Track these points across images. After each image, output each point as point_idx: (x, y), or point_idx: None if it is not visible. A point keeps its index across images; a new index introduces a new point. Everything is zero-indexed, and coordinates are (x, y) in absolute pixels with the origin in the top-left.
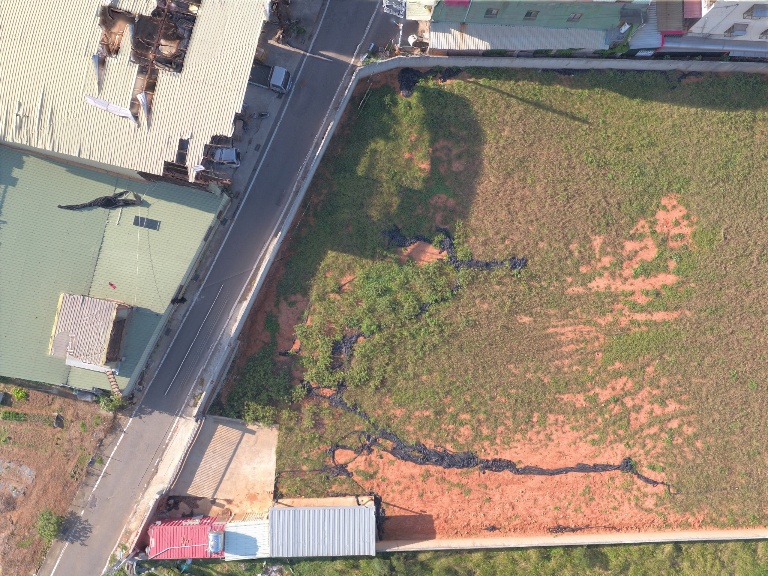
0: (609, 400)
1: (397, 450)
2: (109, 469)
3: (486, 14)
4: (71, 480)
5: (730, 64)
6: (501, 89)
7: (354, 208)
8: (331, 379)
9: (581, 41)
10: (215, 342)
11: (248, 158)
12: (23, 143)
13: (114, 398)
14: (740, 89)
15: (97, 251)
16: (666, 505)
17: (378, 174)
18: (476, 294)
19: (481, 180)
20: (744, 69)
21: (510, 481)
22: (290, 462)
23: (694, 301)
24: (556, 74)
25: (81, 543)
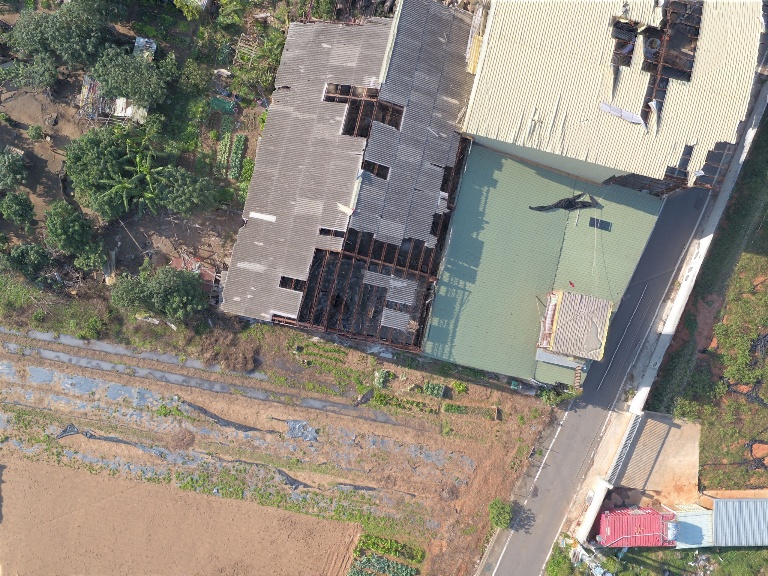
0: None
1: None
2: (548, 460)
3: None
4: (510, 471)
5: None
6: None
7: (765, 212)
8: (751, 376)
9: None
10: (643, 339)
11: None
12: (533, 147)
13: (573, 392)
14: None
15: (559, 251)
16: None
17: None
18: None
19: None
20: None
21: None
22: (712, 455)
23: None
24: None
25: (526, 531)
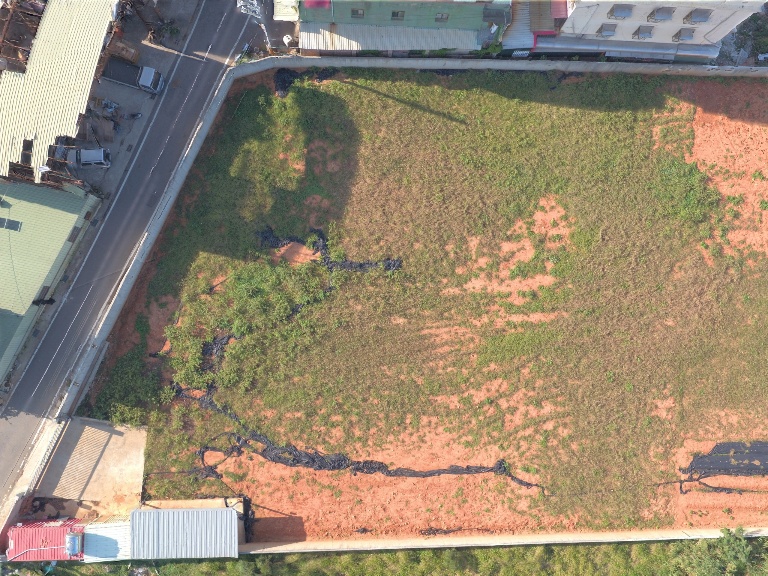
0: (483, 402)
1: (267, 452)
2: None
3: (353, 14)
4: None
5: (608, 64)
6: (377, 89)
7: (226, 209)
8: (200, 380)
9: (453, 41)
10: (83, 343)
11: (120, 159)
12: None
13: None
14: (620, 89)
15: None
16: (540, 507)
17: (251, 175)
18: (349, 295)
19: (356, 181)
20: (624, 69)
21: (382, 483)
22: (158, 464)
23: (571, 302)
24: (434, 74)
25: None
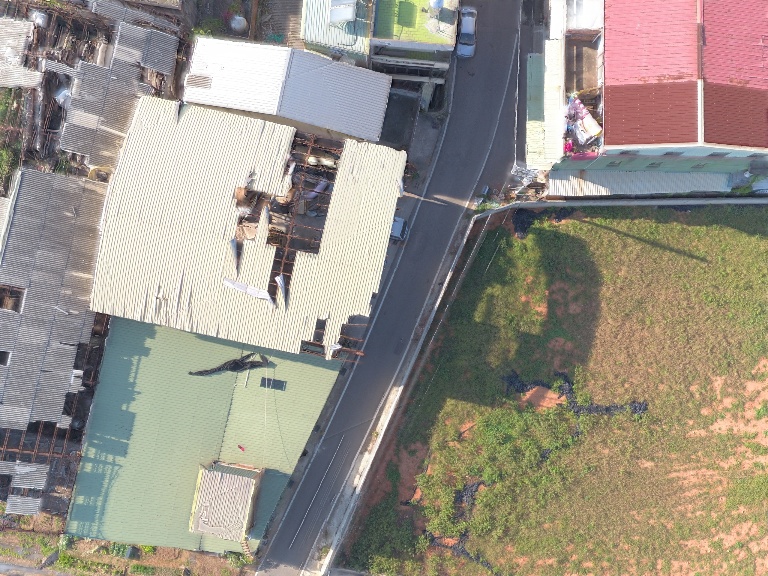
0: (734, 546)
1: None
2: None
3: (608, 164)
4: None
5: None
6: (617, 228)
7: (472, 355)
8: (453, 530)
9: (703, 184)
10: (337, 494)
11: None
12: (162, 324)
13: (245, 560)
14: None
15: (226, 414)
16: None
17: (495, 319)
18: (597, 440)
19: (599, 322)
20: None
21: None
22: None
23: None
24: (672, 210)
25: None
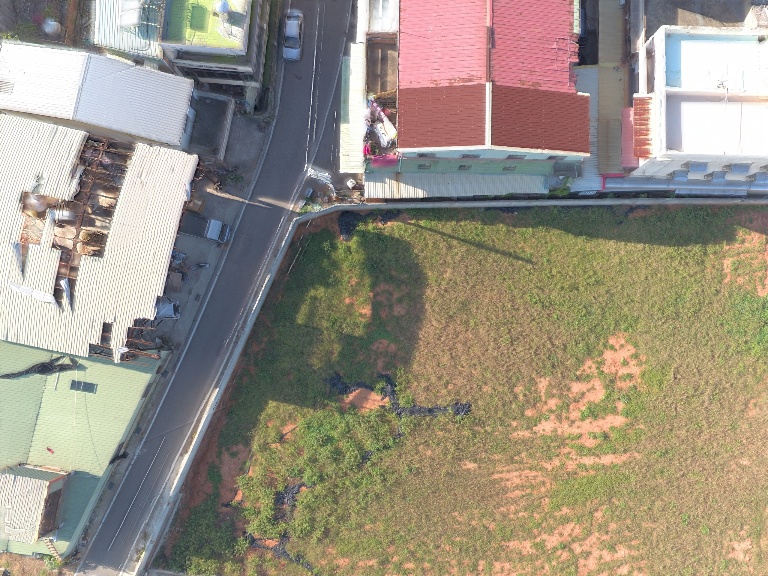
0: (556, 547)
1: None
2: None
3: (420, 166)
4: None
5: (677, 200)
6: (442, 230)
7: (294, 357)
8: (272, 531)
9: (520, 186)
10: (157, 496)
11: (188, 309)
12: None
13: (54, 562)
14: (690, 222)
15: (35, 417)
16: None
17: (318, 322)
18: (418, 442)
19: (423, 324)
20: (694, 202)
21: None
22: None
23: (643, 443)
24: (499, 212)
25: None
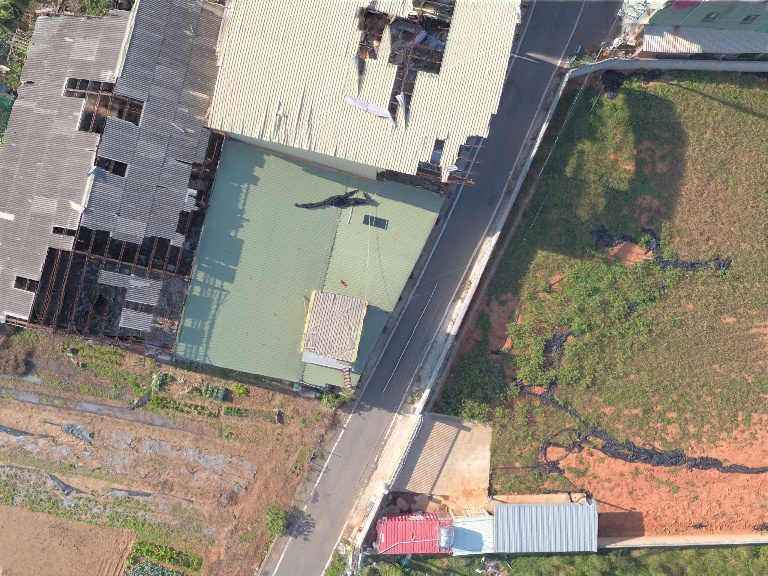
0: None
1: (607, 448)
2: (330, 465)
3: (704, 18)
4: (292, 475)
5: None
6: (703, 92)
7: (563, 208)
8: (544, 377)
9: None
10: (431, 340)
11: None
12: (280, 142)
13: (346, 395)
14: None
15: (330, 249)
16: None
17: (586, 175)
18: (682, 294)
19: (685, 182)
20: None
21: (716, 479)
22: (504, 459)
23: None
24: (755, 77)
25: (305, 538)
